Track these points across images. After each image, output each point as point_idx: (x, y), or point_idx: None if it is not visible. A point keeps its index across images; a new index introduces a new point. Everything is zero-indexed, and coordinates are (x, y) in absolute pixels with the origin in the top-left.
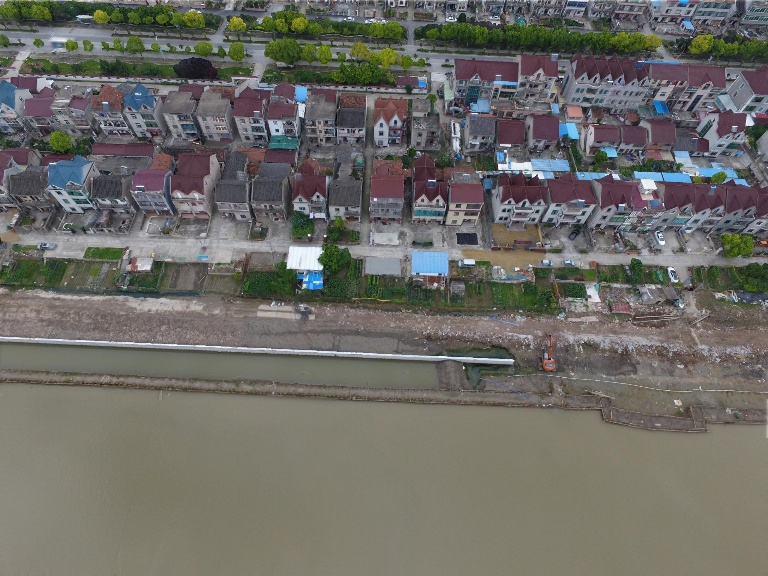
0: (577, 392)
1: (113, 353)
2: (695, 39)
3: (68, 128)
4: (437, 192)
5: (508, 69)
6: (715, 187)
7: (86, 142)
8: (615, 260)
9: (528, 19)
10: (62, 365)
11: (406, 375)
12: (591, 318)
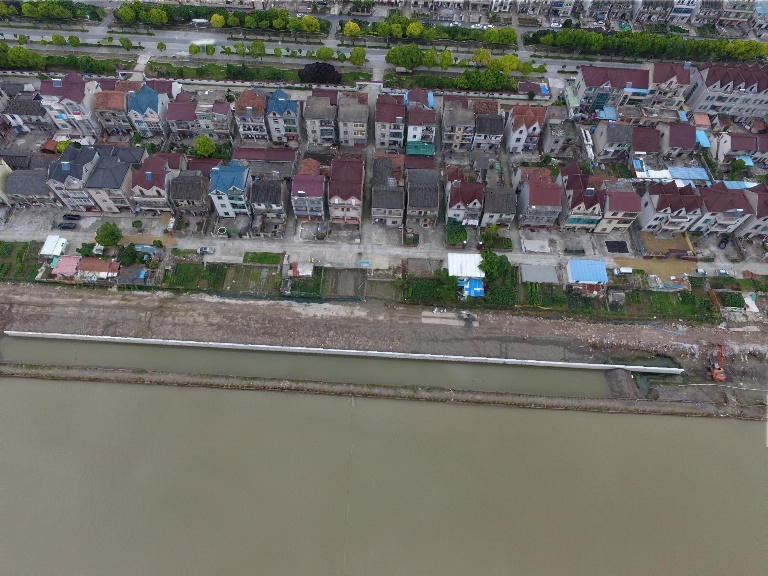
0: (749, 402)
1: (285, 358)
2: None
3: (206, 132)
4: (595, 200)
5: (638, 76)
6: None
7: (227, 146)
8: (767, 270)
9: (632, 25)
10: (235, 369)
11: (576, 383)
12: (752, 328)
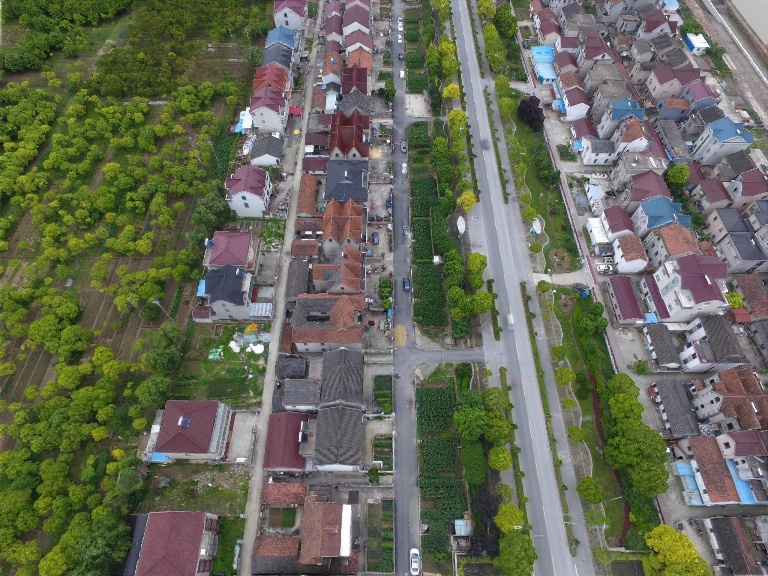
0: None
1: None
2: None
3: None
4: None
5: None
6: None
7: None
8: None
9: None
10: None
11: (727, 24)
12: None
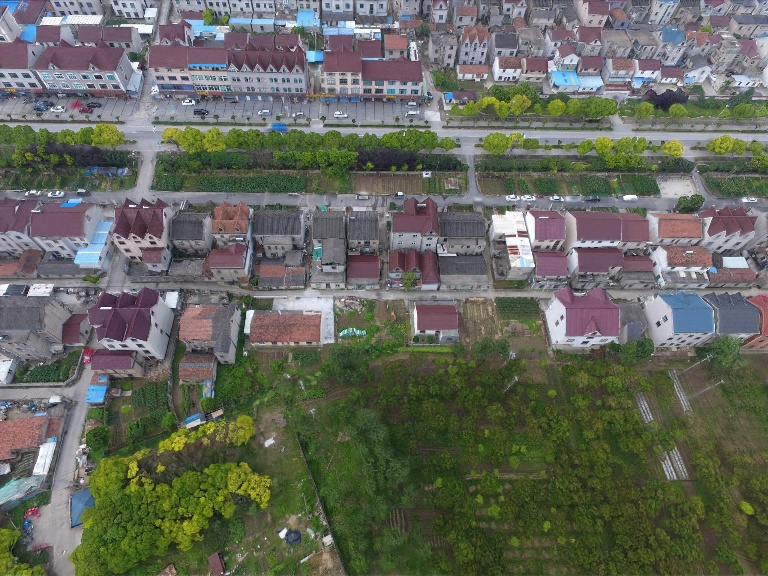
0: None
1: None
2: None
3: None
4: None
5: None
6: None
7: None
8: None
9: None
10: None
11: None
12: None
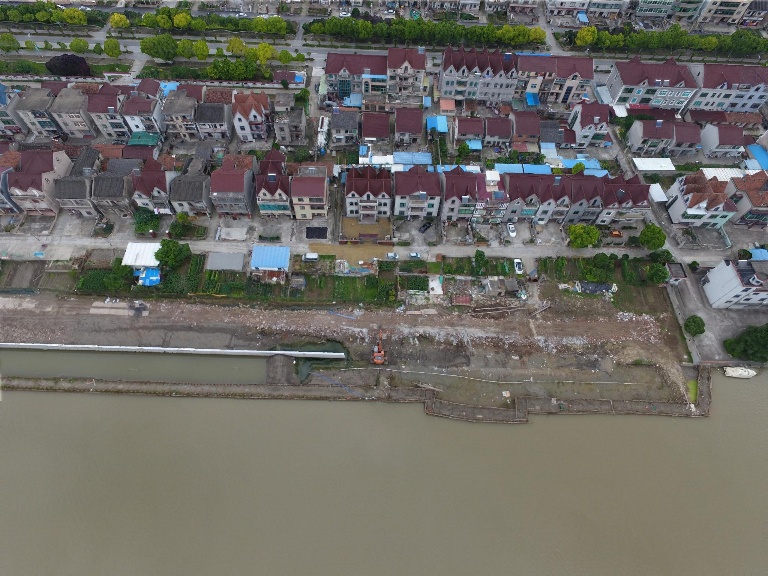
0: (405, 385)
1: None
2: (580, 31)
3: None
4: (277, 186)
5: (377, 62)
6: (560, 178)
7: None
8: (463, 252)
9: (423, 13)
10: None
11: (234, 370)
12: (430, 310)
